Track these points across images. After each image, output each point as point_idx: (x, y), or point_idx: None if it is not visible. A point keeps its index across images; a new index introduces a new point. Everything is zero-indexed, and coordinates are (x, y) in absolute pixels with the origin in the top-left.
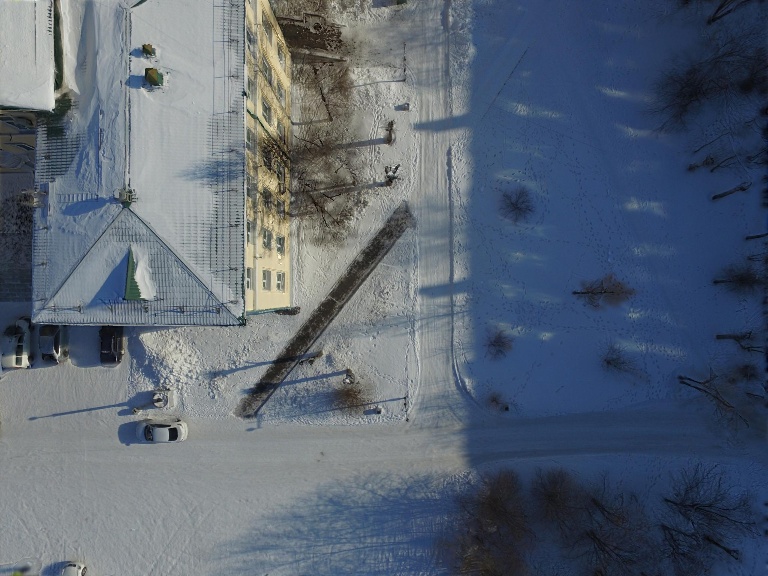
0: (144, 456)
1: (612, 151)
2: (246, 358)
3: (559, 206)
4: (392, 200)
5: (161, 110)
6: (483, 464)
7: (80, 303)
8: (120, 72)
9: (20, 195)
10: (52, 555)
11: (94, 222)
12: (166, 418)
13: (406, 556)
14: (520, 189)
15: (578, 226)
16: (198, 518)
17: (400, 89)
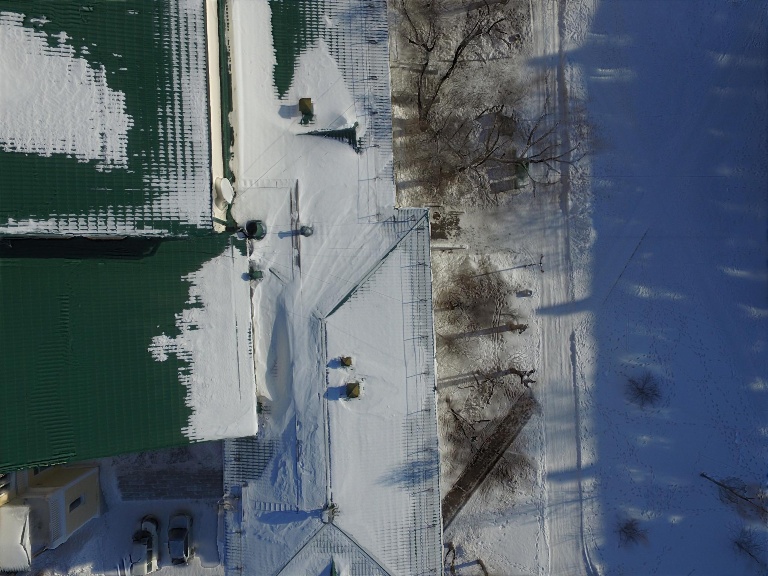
0: None
1: (736, 332)
2: None
3: (685, 389)
4: (517, 387)
5: (358, 418)
6: None
7: None
8: (317, 384)
9: None
10: None
11: (294, 534)
12: None
13: None
14: (646, 375)
15: (704, 408)
16: None
17: (521, 275)
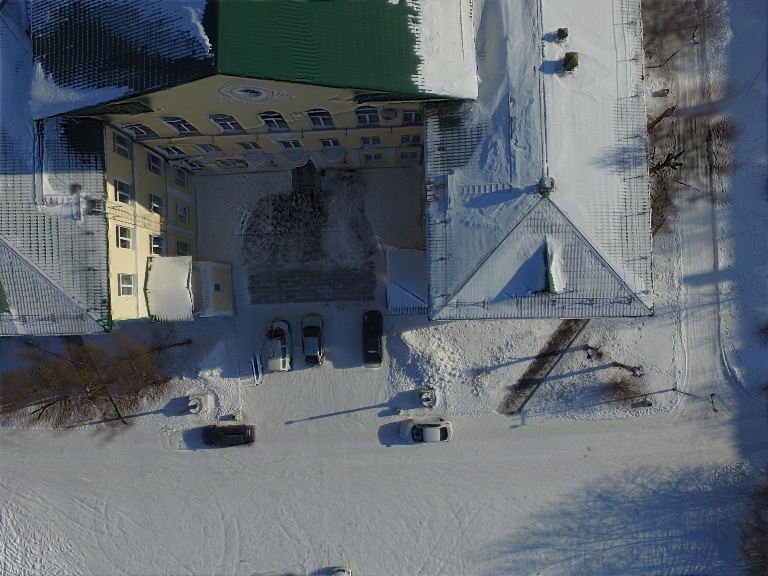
0: (406, 457)
1: None
2: (509, 354)
3: None
4: (652, 188)
5: (572, 96)
6: (755, 454)
7: (484, 298)
8: (533, 58)
9: (275, 194)
10: (315, 561)
11: (506, 214)
12: (427, 418)
13: (680, 550)
14: None
15: None
16: (465, 518)
17: (656, 75)
